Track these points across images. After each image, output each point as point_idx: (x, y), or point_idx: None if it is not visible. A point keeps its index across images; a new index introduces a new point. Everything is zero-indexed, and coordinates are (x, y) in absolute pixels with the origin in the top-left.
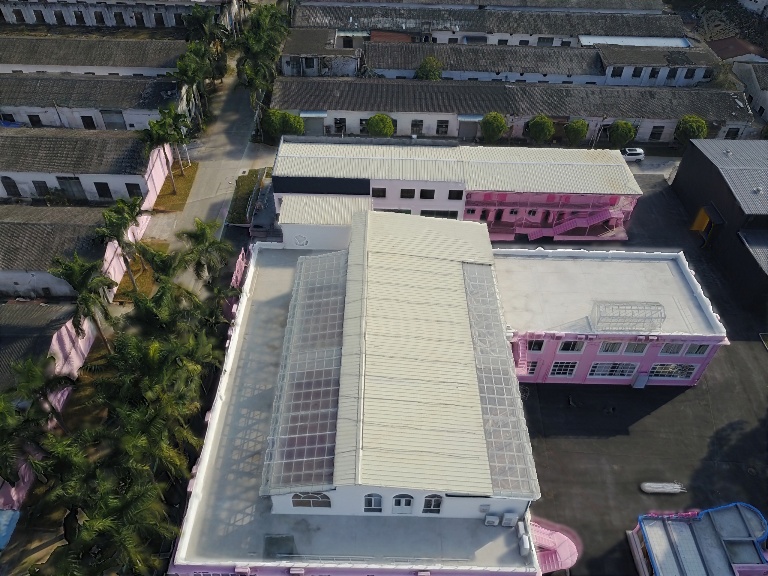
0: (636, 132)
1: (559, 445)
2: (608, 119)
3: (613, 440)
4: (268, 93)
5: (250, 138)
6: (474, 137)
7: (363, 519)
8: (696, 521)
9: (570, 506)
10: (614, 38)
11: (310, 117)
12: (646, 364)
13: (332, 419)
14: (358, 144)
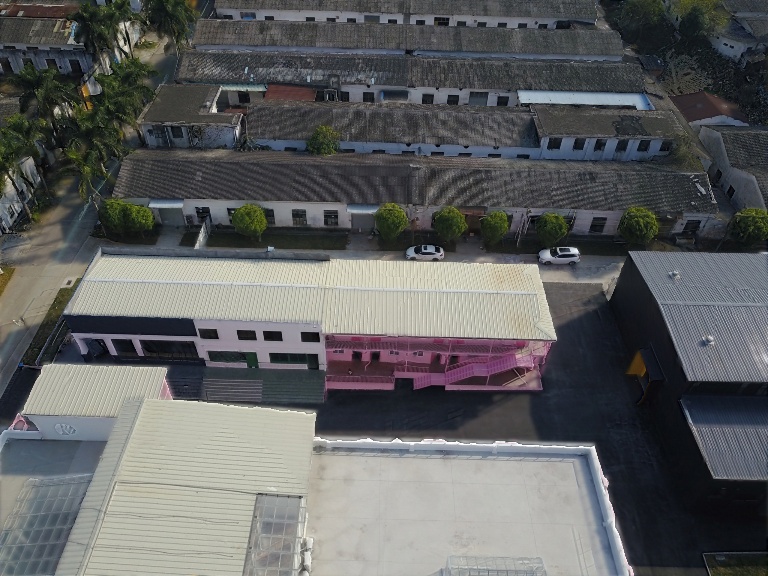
0: (572, 224)
1: None
2: (536, 210)
3: None
4: (113, 175)
5: (92, 230)
6: (372, 228)
7: None
8: None
9: None
10: (560, 94)
11: (161, 208)
12: None
13: None
14: (199, 257)
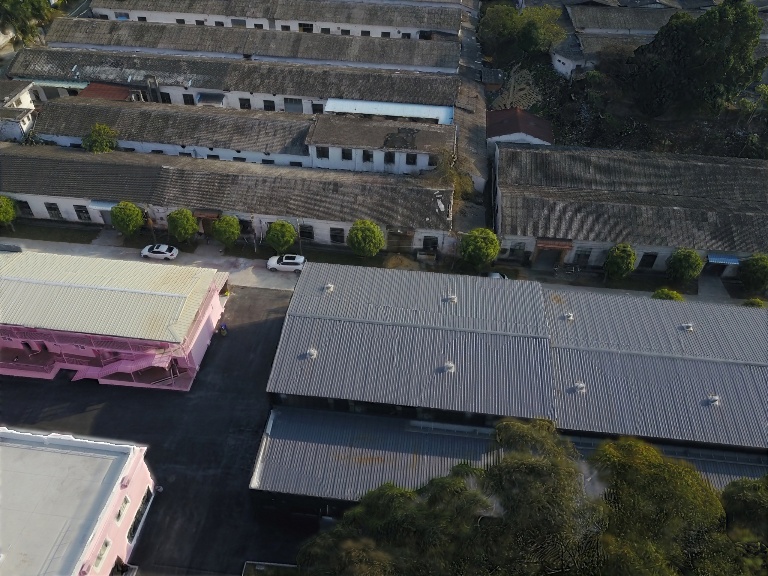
0: (312, 233)
1: None
2: (270, 216)
3: None
4: None
5: None
6: None
7: None
8: None
9: None
10: (368, 103)
11: None
12: None
13: None
14: None
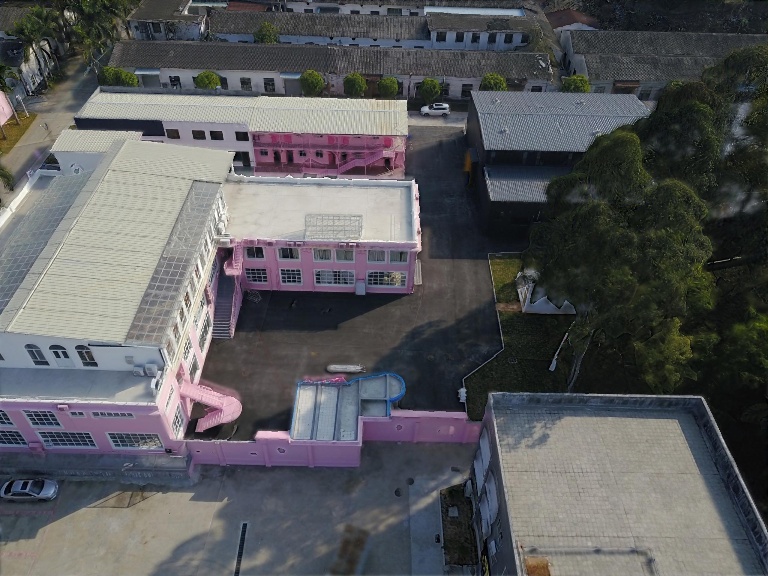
0: (448, 90)
1: (271, 337)
2: (419, 77)
3: (320, 334)
4: (108, 53)
5: None
6: (300, 94)
7: (33, 370)
8: (345, 386)
9: (260, 382)
10: (456, 9)
11: (144, 74)
12: (361, 272)
13: (15, 290)
14: (168, 94)
